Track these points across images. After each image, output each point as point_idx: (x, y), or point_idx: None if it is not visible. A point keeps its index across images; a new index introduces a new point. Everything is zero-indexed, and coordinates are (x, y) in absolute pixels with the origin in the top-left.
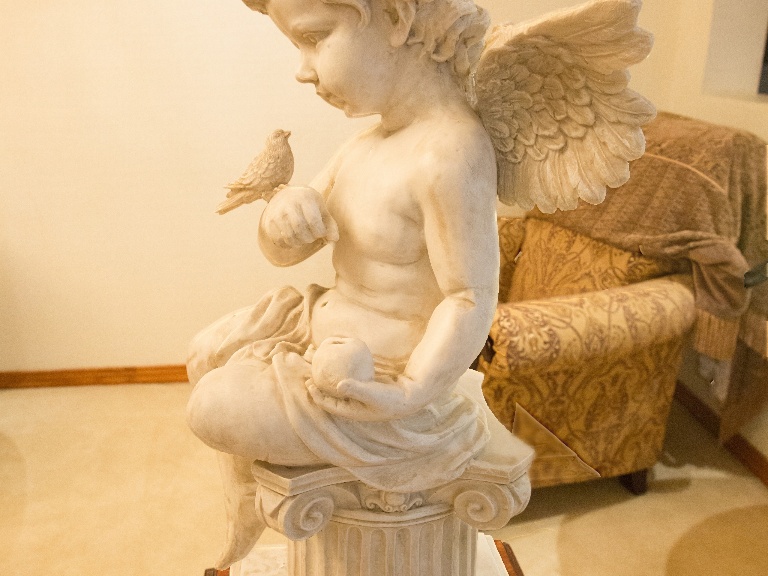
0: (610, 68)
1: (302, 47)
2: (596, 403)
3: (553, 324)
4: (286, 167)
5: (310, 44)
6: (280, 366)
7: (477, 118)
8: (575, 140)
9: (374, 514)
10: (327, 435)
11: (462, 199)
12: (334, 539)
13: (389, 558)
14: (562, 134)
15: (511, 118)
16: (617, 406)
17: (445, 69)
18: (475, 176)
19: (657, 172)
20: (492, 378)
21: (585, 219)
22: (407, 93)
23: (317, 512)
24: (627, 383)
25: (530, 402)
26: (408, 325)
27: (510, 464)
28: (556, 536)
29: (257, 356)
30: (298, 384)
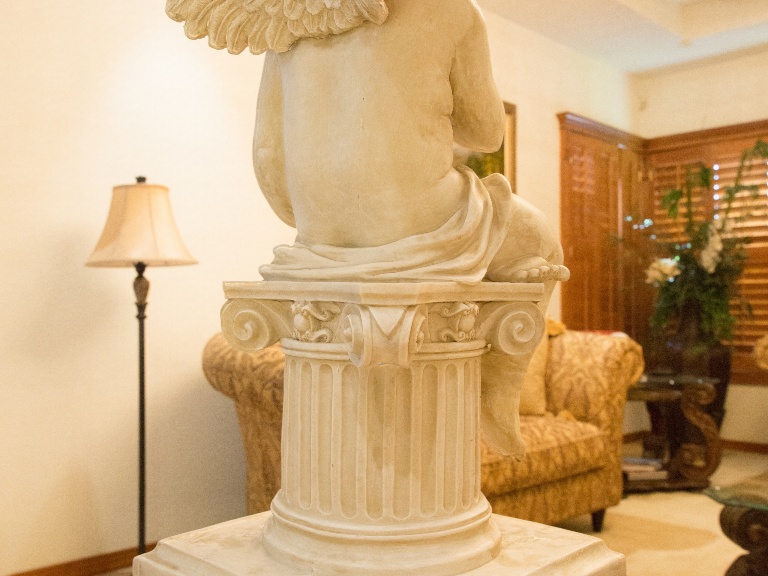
0: None
1: None
2: None
3: None
4: None
5: None
6: None
7: None
8: None
9: None
10: None
11: None
12: None
13: None
14: None
15: None
16: None
17: None
18: None
19: None
20: None
21: None
22: None
23: None
24: None
25: None
26: None
27: None
28: None
29: None
30: None
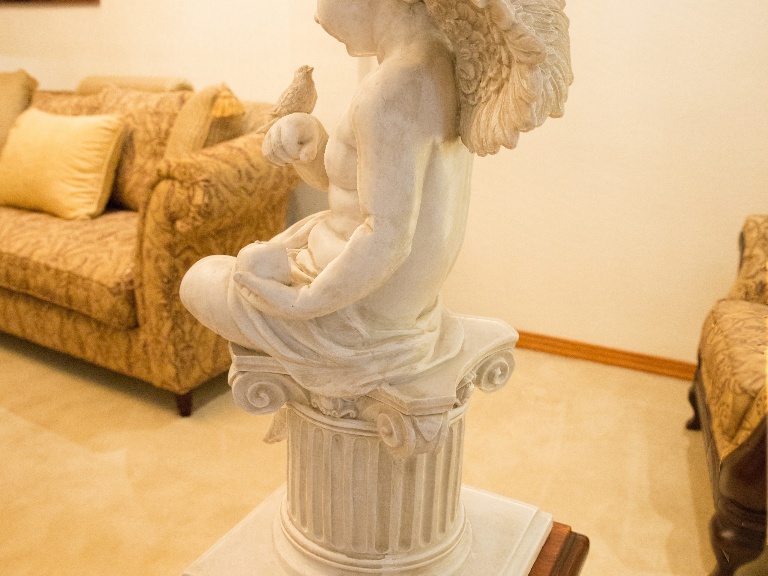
0: None
1: None
2: None
3: None
4: (302, 98)
5: None
6: None
7: (436, 58)
8: None
9: (314, 412)
10: (254, 323)
11: (372, 129)
12: None
13: (326, 457)
14: None
15: (478, 60)
16: None
17: (420, 10)
18: (388, 109)
19: None
20: None
21: None
22: (382, 33)
23: (264, 393)
24: None
25: None
26: None
27: (413, 397)
28: None
29: None
30: None
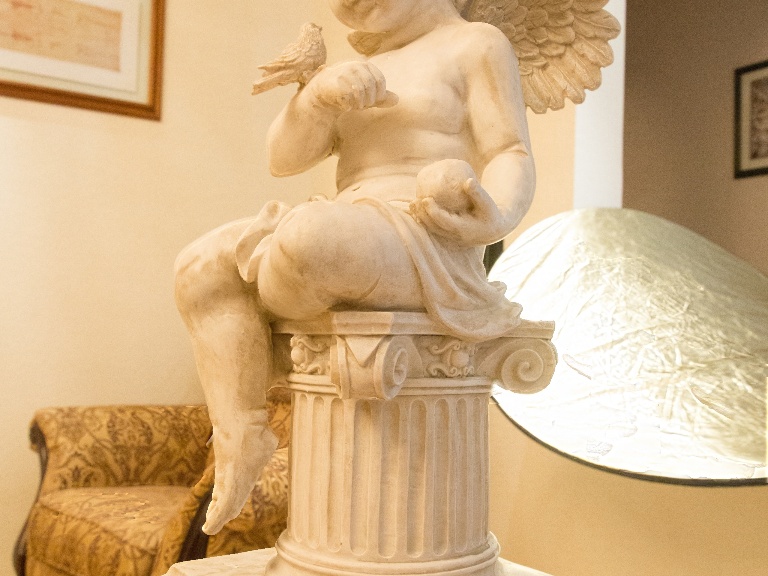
0: None
1: None
2: None
3: None
4: (324, 53)
5: None
6: None
7: None
8: (555, 58)
9: (440, 379)
10: (432, 258)
11: (509, 68)
12: (392, 423)
13: (452, 432)
14: (542, 56)
15: None
16: None
17: None
18: (513, 54)
19: None
20: (227, 539)
21: None
22: (429, 4)
23: (402, 364)
24: None
25: None
26: None
27: None
28: None
29: None
30: None
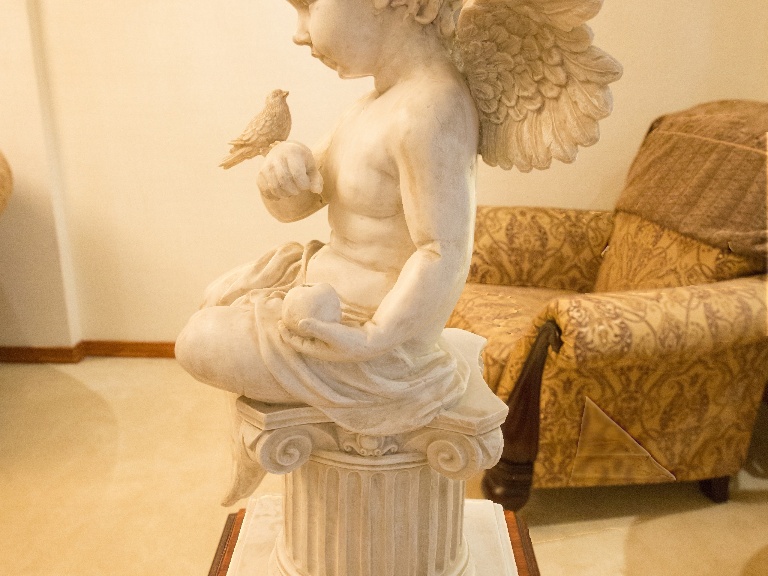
0: (569, 25)
1: (299, 11)
2: (673, 403)
3: (626, 317)
4: (282, 125)
5: (305, 8)
6: (259, 307)
7: (459, 79)
8: (551, 100)
9: (350, 456)
10: (297, 373)
11: (430, 154)
12: (316, 479)
13: (364, 500)
14: (540, 95)
15: (496, 80)
16: (696, 408)
17: (431, 31)
18: (444, 132)
19: (753, 166)
20: None
21: (674, 213)
22: (393, 54)
23: (293, 449)
24: (708, 384)
25: (601, 397)
26: (385, 276)
27: (479, 416)
28: (625, 536)
29: (252, 302)
30: (273, 324)
